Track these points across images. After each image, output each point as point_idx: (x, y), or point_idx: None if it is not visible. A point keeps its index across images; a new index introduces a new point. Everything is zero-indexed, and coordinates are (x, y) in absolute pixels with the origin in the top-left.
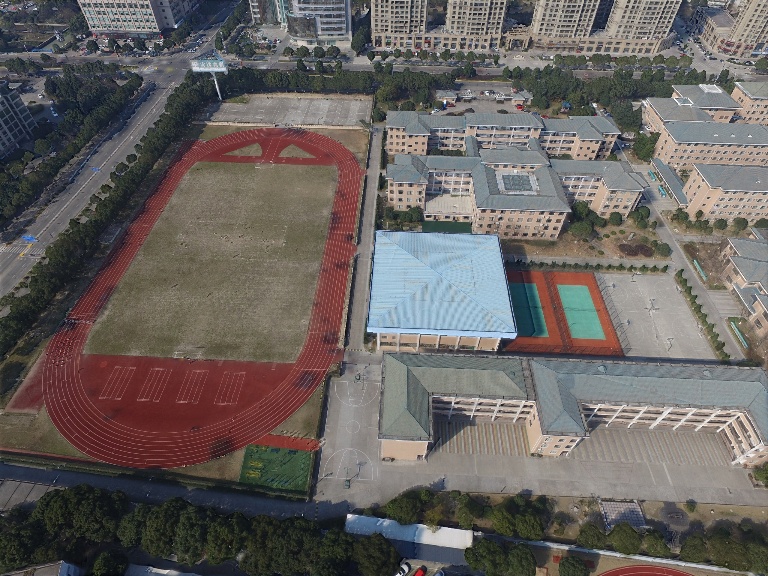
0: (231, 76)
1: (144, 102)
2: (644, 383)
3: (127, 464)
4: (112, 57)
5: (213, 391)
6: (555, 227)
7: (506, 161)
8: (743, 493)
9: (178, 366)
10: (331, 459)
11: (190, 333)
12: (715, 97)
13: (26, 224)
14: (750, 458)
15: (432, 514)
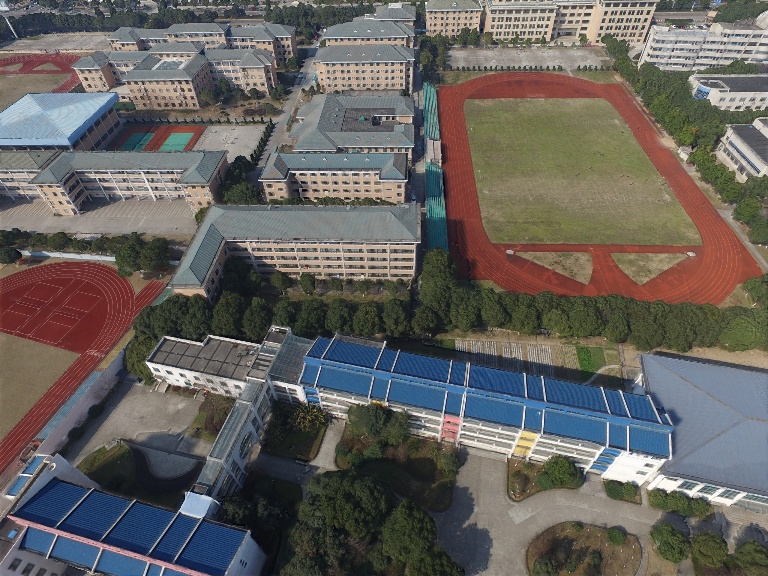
0: (25, 18)
1: None
2: (122, 156)
3: None
4: None
5: None
6: (191, 96)
7: (165, 51)
8: (185, 229)
9: None
10: None
11: None
12: (395, 11)
13: None
14: (196, 206)
15: None
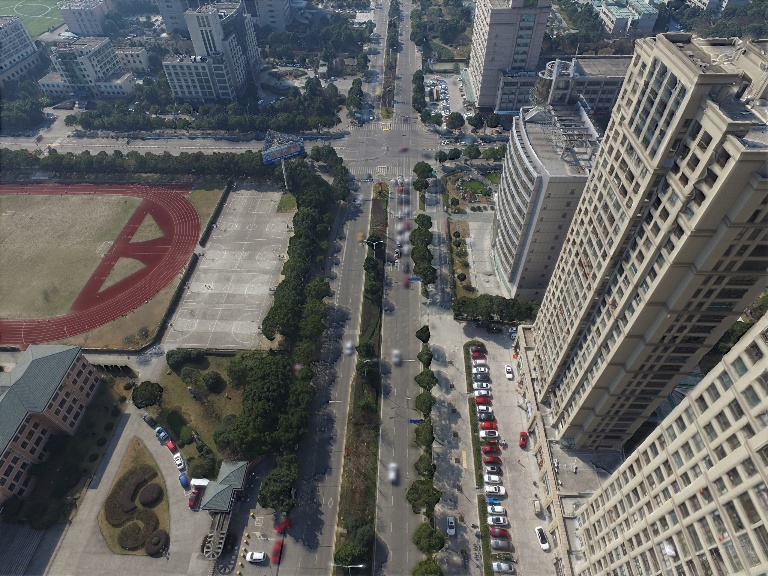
0: (304, 178)
1: None
2: None
3: None
4: None
5: None
6: None
7: None
8: None
9: None
10: None
11: None
12: None
13: (90, 136)
14: None
15: None
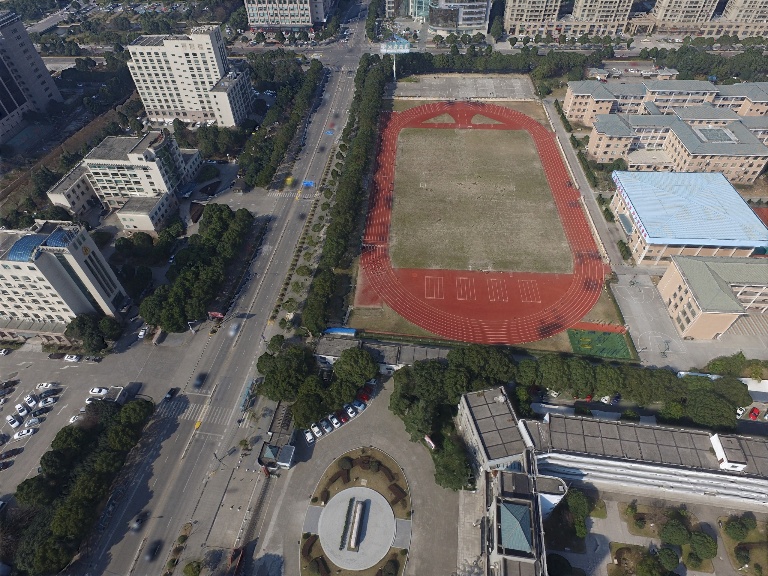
0: (404, 58)
1: (327, 83)
2: None
3: (476, 341)
4: (276, 47)
5: (517, 293)
6: (754, 171)
7: (703, 117)
8: None
9: (477, 276)
10: (641, 338)
11: (473, 253)
12: None
13: (286, 176)
14: None
15: (755, 369)
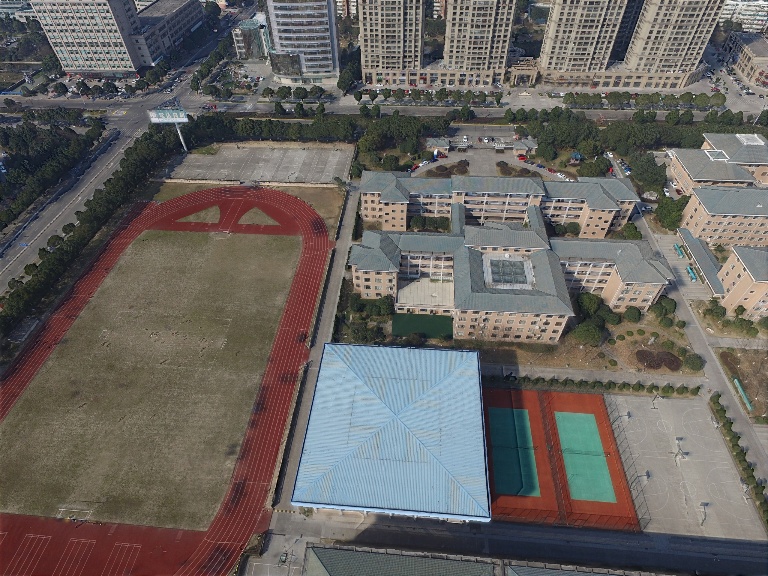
0: (198, 124)
1: (103, 154)
2: None
3: None
4: (82, 100)
5: (94, 575)
6: (555, 330)
7: (495, 244)
8: None
9: (59, 532)
10: None
11: (85, 479)
12: (756, 150)
13: None
14: None
15: None
